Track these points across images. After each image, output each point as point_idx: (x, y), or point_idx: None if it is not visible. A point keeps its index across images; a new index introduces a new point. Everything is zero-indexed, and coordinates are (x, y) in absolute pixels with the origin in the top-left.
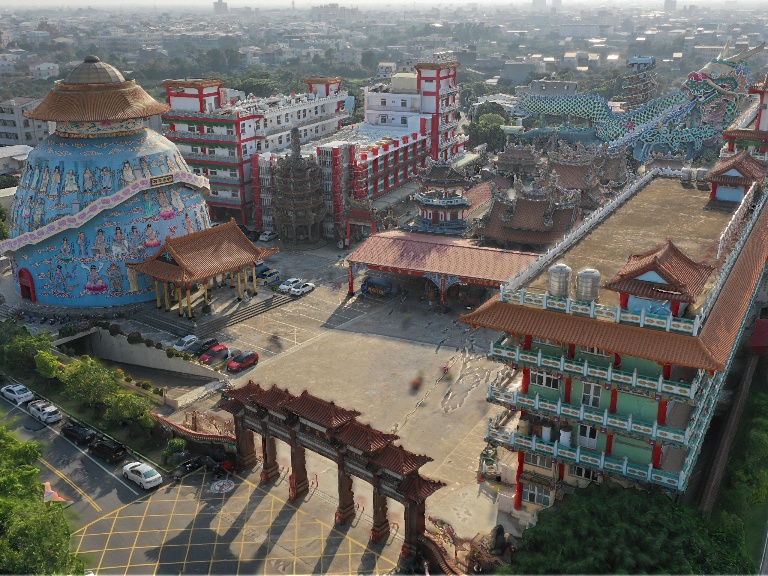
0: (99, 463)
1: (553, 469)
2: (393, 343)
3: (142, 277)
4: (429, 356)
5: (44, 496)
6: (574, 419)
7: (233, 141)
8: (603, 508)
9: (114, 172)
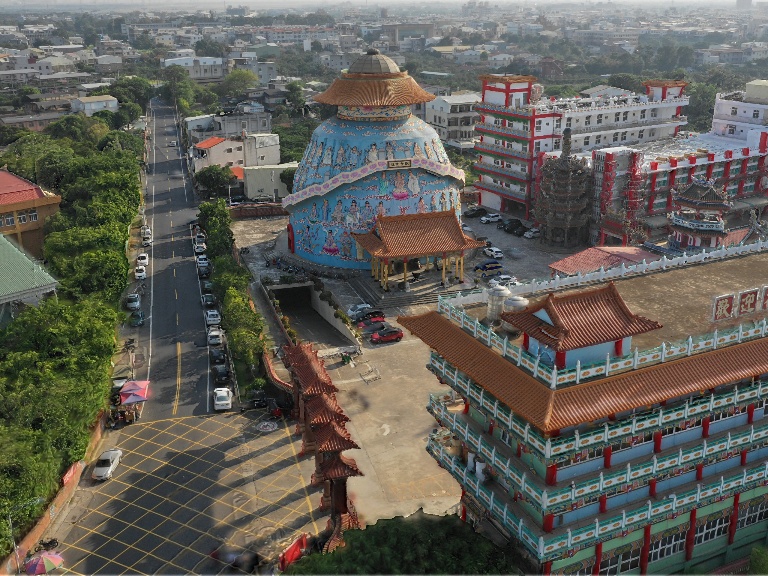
0: (209, 382)
1: None
2: None
3: None
4: None
5: (135, 389)
6: (474, 449)
7: (525, 137)
8: (392, 530)
9: (361, 152)
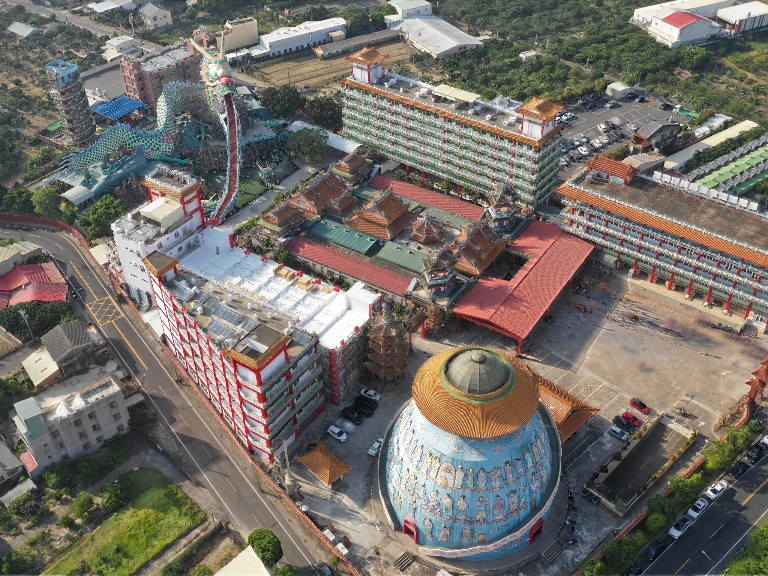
0: (762, 459)
1: None
2: (602, 345)
3: None
4: (619, 334)
5: None
6: None
7: None
8: None
9: None
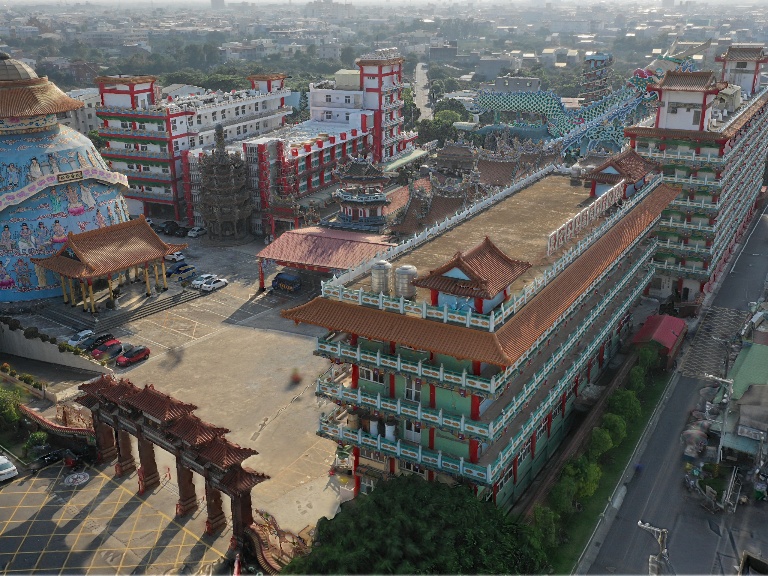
0: None
1: (384, 463)
2: (289, 338)
3: (50, 272)
4: None
5: None
6: (392, 413)
7: (163, 137)
8: (388, 500)
9: (21, 168)
